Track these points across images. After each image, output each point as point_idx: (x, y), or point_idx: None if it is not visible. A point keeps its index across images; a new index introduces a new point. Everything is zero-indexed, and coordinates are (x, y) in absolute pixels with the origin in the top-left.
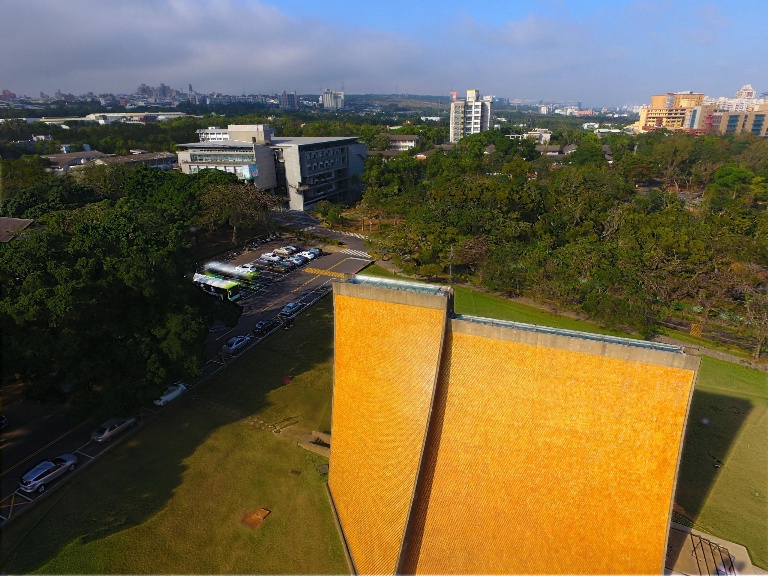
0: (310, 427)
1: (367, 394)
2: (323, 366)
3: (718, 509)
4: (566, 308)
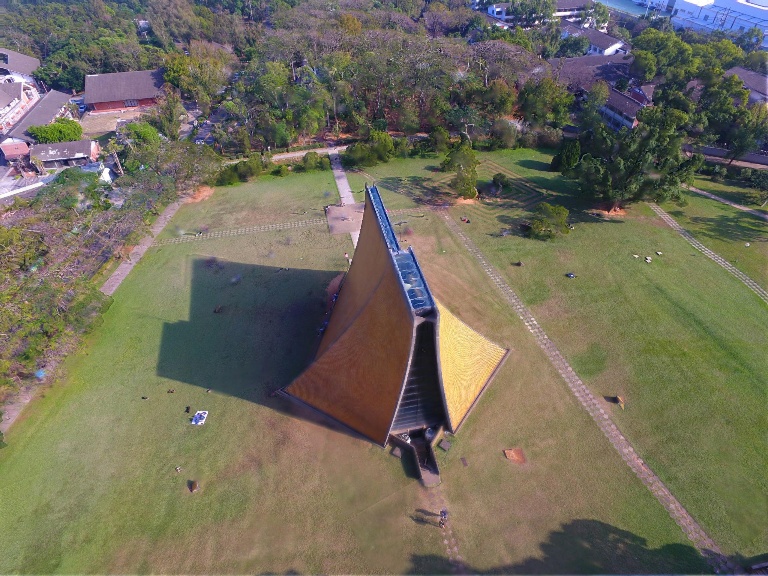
0: (414, 492)
1: (442, 346)
2: (307, 569)
3: (327, 267)
4: (83, 349)
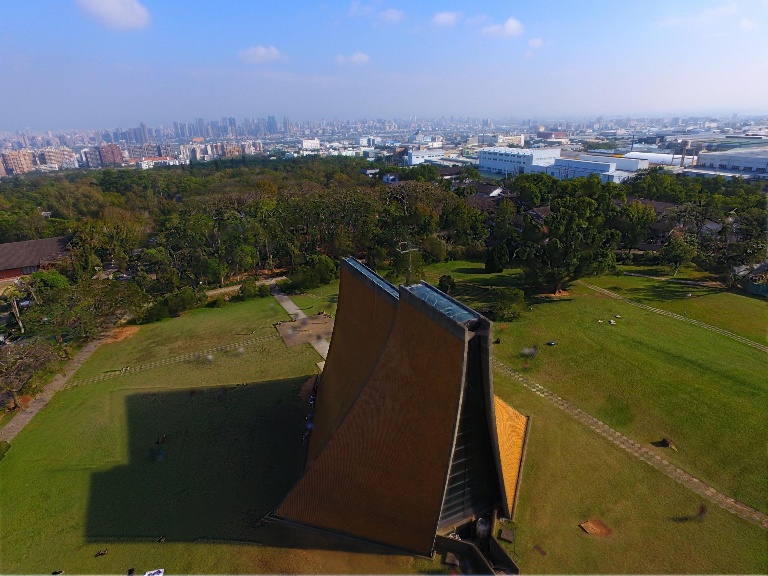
0: None
1: None
2: None
3: (293, 374)
4: None
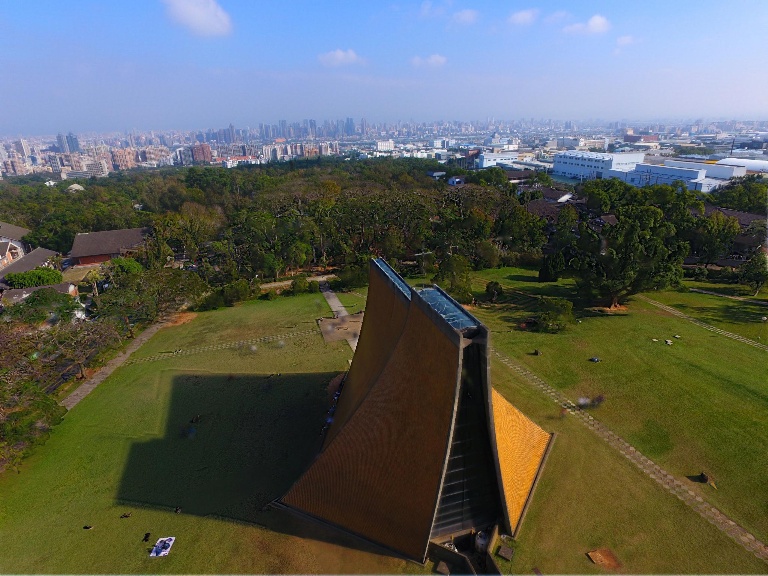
0: None
1: None
2: None
3: (324, 369)
4: (15, 465)
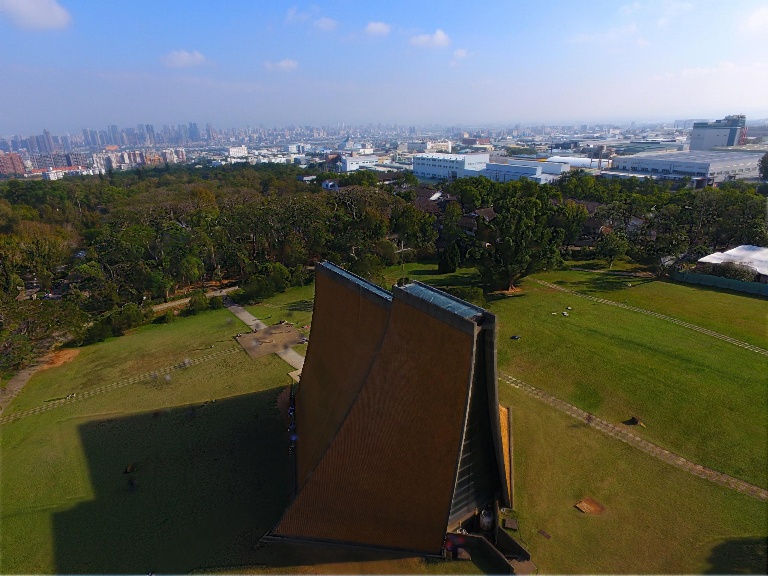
0: None
1: None
2: None
3: None
4: None
